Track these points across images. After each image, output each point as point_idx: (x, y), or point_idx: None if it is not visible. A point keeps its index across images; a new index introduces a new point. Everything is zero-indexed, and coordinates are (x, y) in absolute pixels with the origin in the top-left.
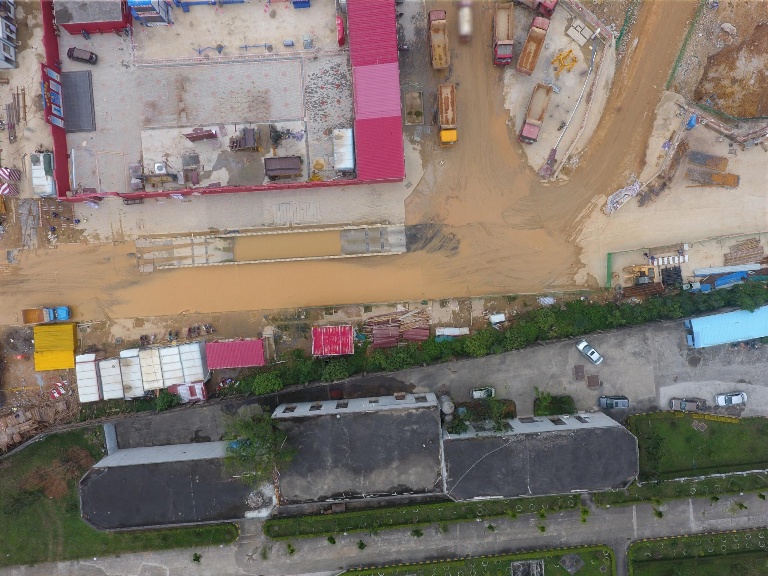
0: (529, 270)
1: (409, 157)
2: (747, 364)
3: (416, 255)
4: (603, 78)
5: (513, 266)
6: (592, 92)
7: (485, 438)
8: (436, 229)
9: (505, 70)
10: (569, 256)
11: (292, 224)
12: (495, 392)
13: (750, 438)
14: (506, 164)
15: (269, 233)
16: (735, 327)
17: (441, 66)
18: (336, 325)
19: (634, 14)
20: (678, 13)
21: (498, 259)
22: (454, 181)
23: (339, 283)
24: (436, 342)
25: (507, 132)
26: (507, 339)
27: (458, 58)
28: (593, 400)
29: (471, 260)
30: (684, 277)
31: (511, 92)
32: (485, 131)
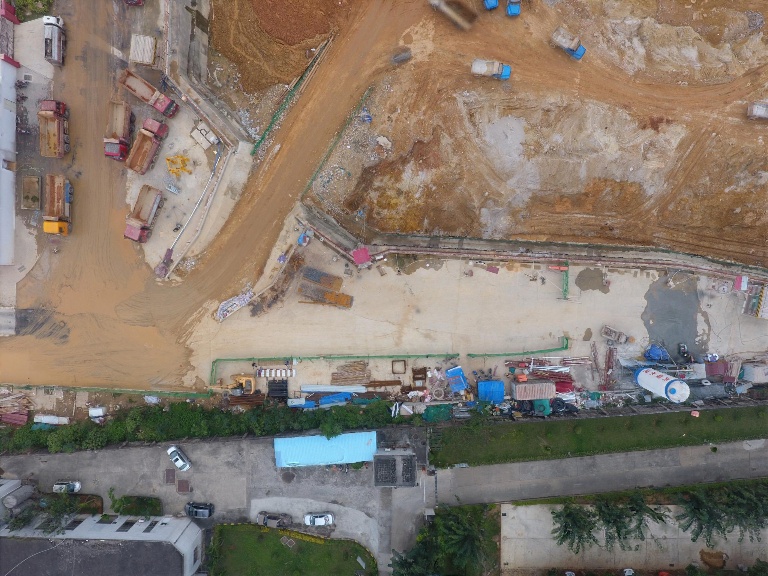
0: (138, 367)
1: (24, 241)
2: (341, 486)
3: (25, 339)
4: (225, 184)
5: (122, 361)
6: (210, 197)
7: (32, 539)
8: (47, 315)
9: None
10: (179, 357)
11: None
12: (81, 487)
13: (337, 559)
14: (123, 258)
15: None
16: (331, 448)
17: (51, 156)
18: None
19: (280, 120)
20: (327, 123)
21: (107, 352)
22: (69, 270)
23: None
24: (27, 430)
25: None
26: (88, 437)
27: (82, 147)
28: (182, 505)
29: (80, 350)
30: (291, 391)
31: (132, 187)
32: (104, 223)
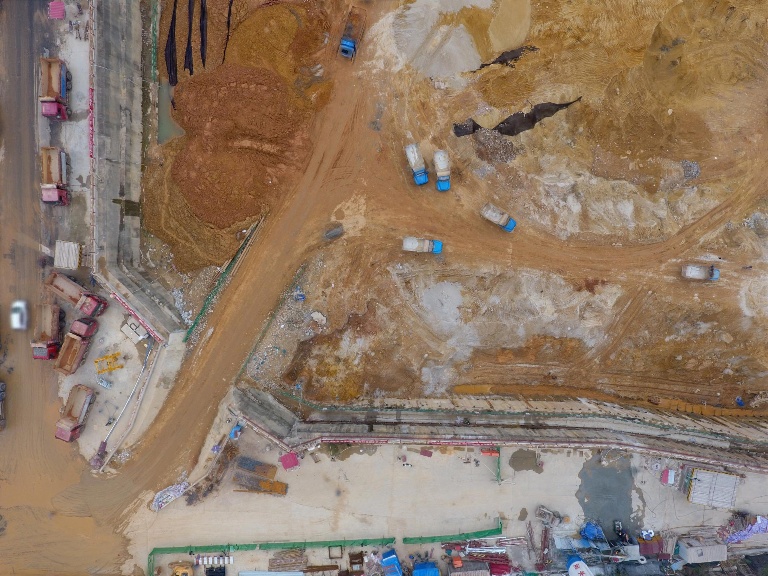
0: (76, 557)
1: None
2: None
3: None
4: (156, 376)
5: (60, 552)
6: None
7: None
8: None
9: None
10: (117, 546)
11: None
12: None
13: None
14: (58, 451)
15: None
16: None
17: None
18: None
19: (212, 303)
20: (260, 304)
21: (45, 544)
22: (4, 464)
23: None
24: None
25: None
26: None
27: (13, 343)
28: None
29: (17, 542)
30: None
31: (64, 382)
32: (38, 417)
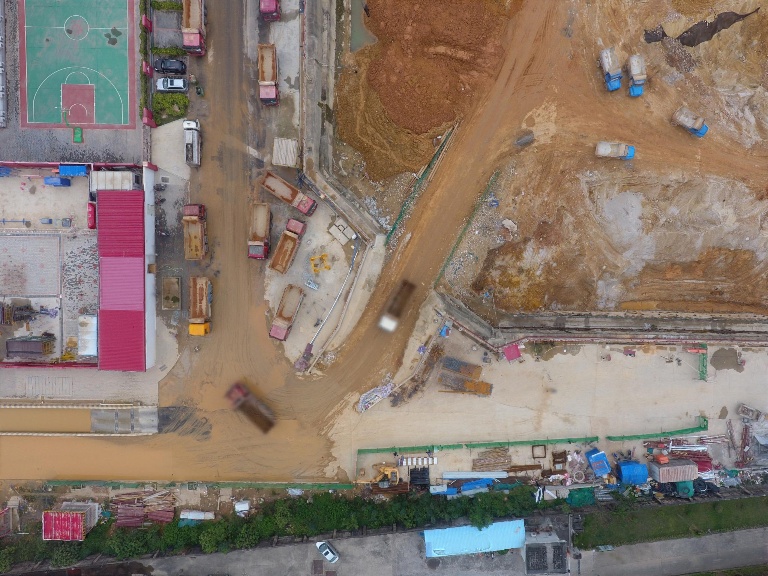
0: (280, 459)
1: (165, 341)
2: (486, 570)
3: (167, 437)
4: (363, 278)
5: (264, 454)
6: (349, 292)
7: None
8: (189, 413)
9: (267, 261)
10: (321, 449)
11: (44, 397)
12: None
13: None
14: (263, 354)
15: (17, 407)
16: None
17: (194, 259)
18: (83, 500)
19: (409, 209)
20: (455, 210)
21: (249, 446)
22: (210, 367)
23: (90, 458)
24: (176, 528)
25: (266, 322)
26: (240, 535)
27: (220, 246)
28: None
29: (222, 445)
30: (432, 478)
31: (271, 284)
32: (244, 320)
